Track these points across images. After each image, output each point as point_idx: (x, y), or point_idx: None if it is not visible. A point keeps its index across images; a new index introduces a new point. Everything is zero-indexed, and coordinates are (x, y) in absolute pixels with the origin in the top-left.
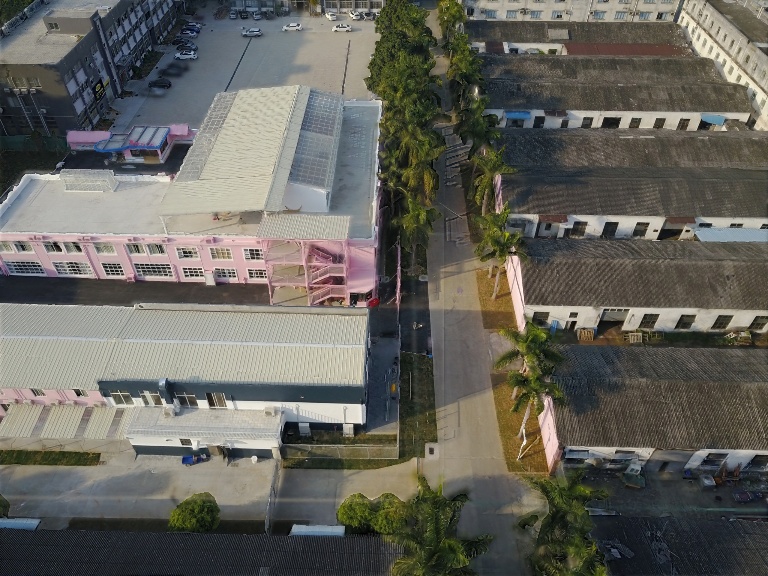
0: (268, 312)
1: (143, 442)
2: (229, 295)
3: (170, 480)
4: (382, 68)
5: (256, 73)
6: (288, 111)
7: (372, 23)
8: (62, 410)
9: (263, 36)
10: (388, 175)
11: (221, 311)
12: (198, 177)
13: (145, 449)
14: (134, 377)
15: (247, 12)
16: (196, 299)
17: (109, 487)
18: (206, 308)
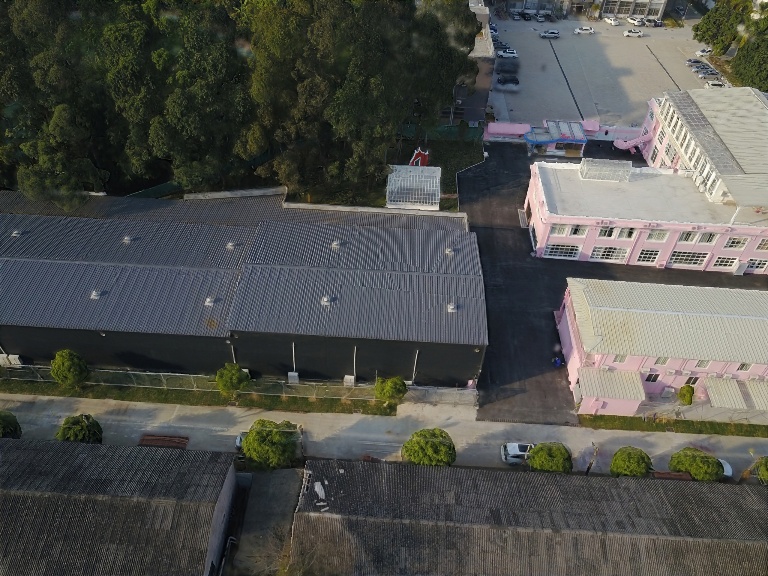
0: None
1: None
2: (762, 285)
3: None
4: None
5: (585, 74)
6: (767, 112)
7: (654, 29)
8: (757, 385)
9: (560, 38)
10: None
11: None
12: (741, 171)
13: None
14: None
15: (529, 14)
16: (735, 287)
17: None
18: None
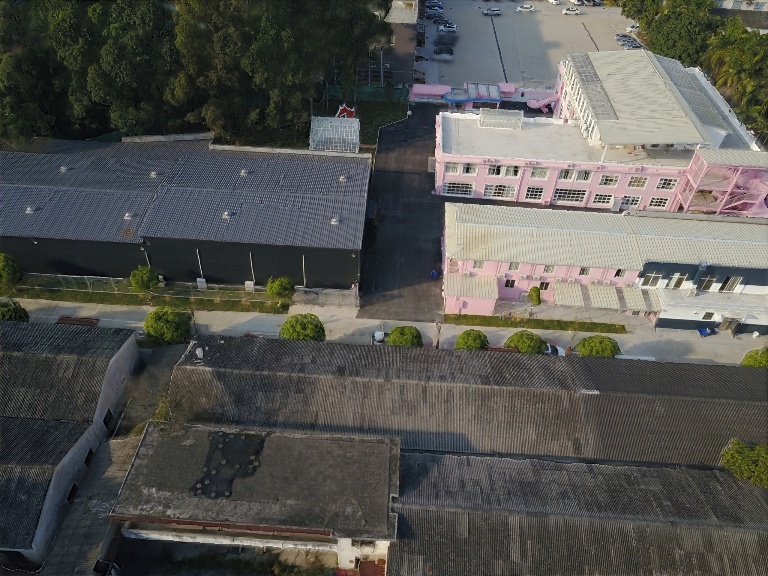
0: (735, 222)
1: (671, 315)
2: None
3: (695, 346)
4: (677, 42)
5: (519, 46)
6: (653, 69)
7: (593, 8)
8: (597, 288)
9: (502, 15)
10: (763, 124)
11: (696, 220)
12: (615, 117)
13: (665, 322)
14: (667, 262)
15: None
16: None
17: (649, 349)
18: (684, 217)
